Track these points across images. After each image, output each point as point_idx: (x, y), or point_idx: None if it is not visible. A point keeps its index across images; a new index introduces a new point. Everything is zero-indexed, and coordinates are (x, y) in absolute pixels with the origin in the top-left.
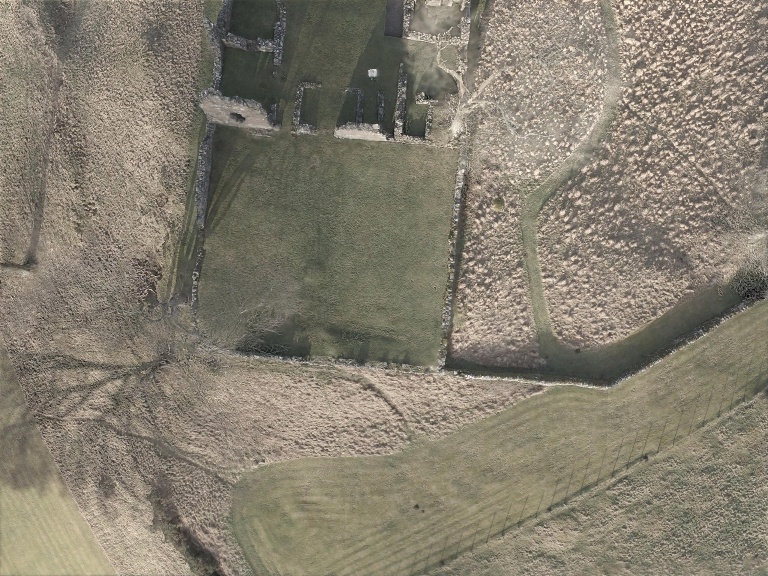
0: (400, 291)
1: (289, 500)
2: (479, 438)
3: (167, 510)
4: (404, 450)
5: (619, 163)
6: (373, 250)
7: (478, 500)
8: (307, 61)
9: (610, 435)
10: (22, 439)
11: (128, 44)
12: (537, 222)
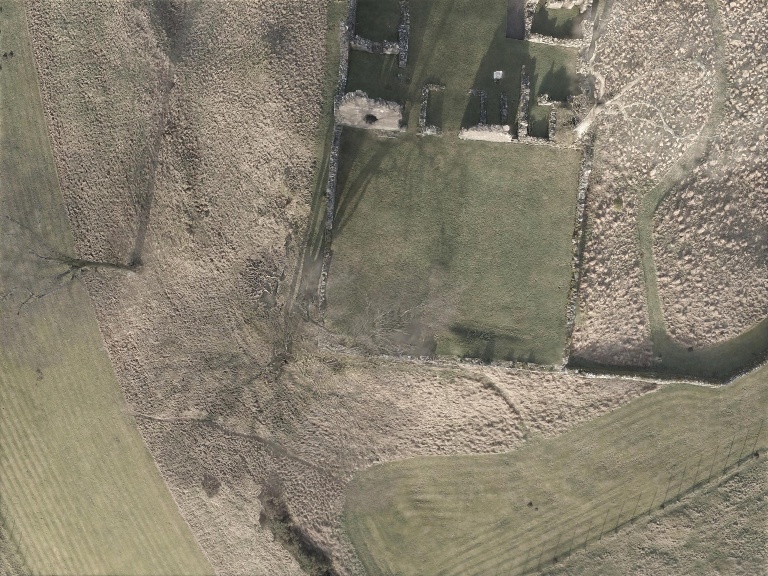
0: (524, 291)
1: (403, 498)
2: (593, 436)
3: (278, 509)
4: (519, 448)
5: (727, 163)
6: (497, 250)
7: (592, 497)
8: (431, 63)
9: (722, 432)
10: (121, 440)
11: (246, 47)
12: (653, 222)
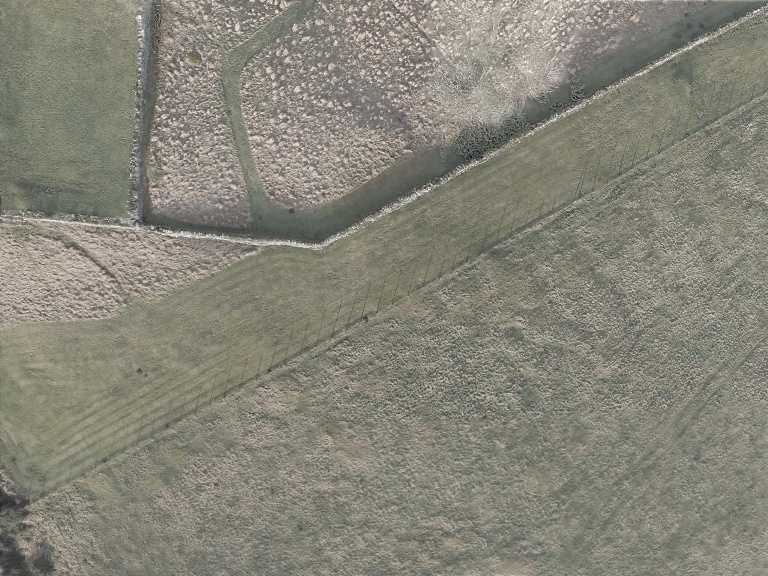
0: (89, 144)
1: (16, 368)
2: (195, 300)
3: None
4: (122, 313)
5: (337, 24)
6: (62, 103)
7: (199, 363)
8: None
9: (328, 296)
10: None
11: None
12: (240, 79)
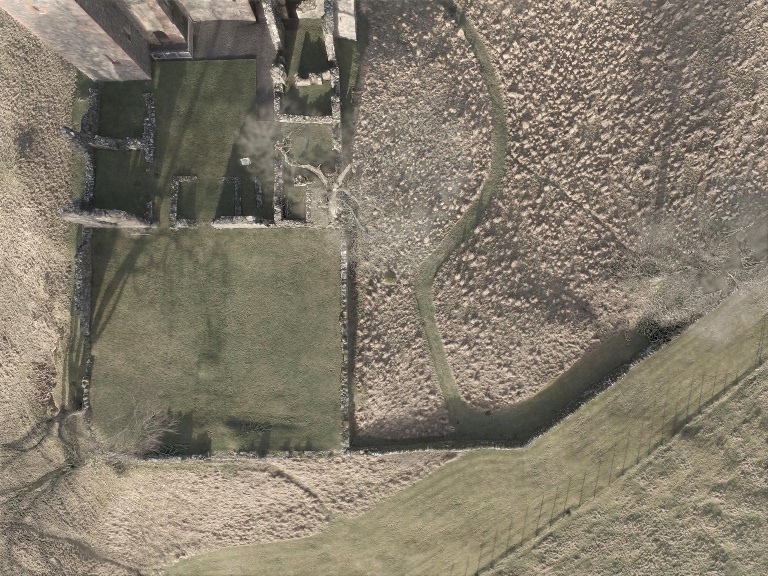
0: (296, 377)
1: None
2: (398, 511)
3: None
4: (323, 530)
5: (513, 218)
6: (265, 338)
7: (404, 573)
8: (180, 154)
9: (530, 494)
10: None
11: (3, 150)
12: (432, 290)
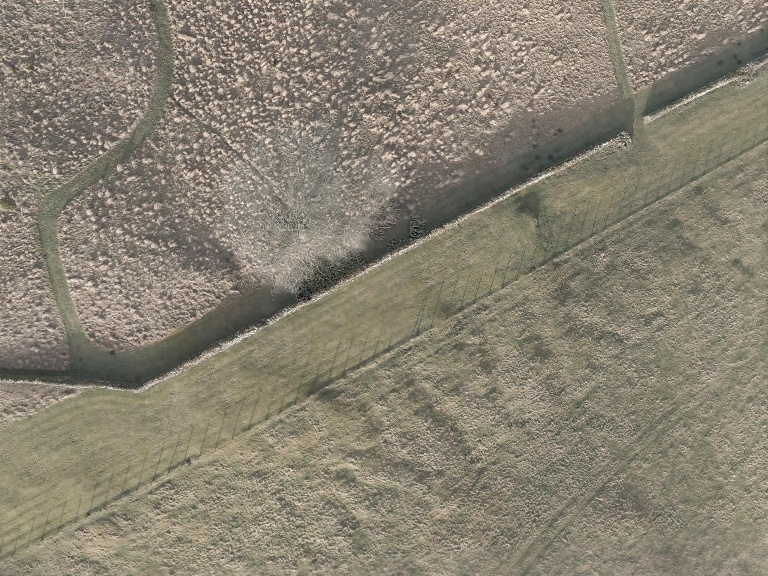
0: None
1: None
2: (13, 442)
3: None
4: None
5: (167, 161)
6: None
7: (17, 504)
8: None
9: (150, 438)
10: None
11: None
12: (58, 222)
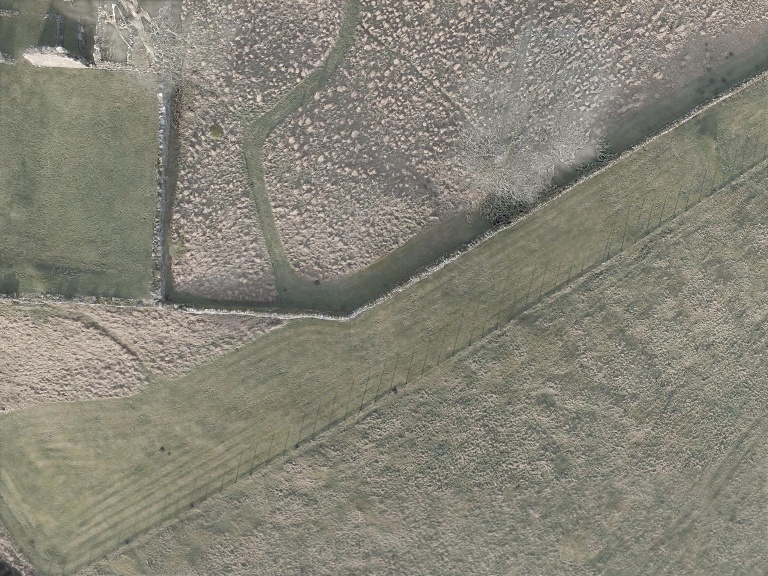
0: (109, 223)
1: (33, 448)
2: (219, 376)
3: None
4: (143, 391)
5: (359, 90)
6: (81, 182)
7: (224, 440)
8: None
9: (356, 368)
10: None
11: None
12: (263, 150)
